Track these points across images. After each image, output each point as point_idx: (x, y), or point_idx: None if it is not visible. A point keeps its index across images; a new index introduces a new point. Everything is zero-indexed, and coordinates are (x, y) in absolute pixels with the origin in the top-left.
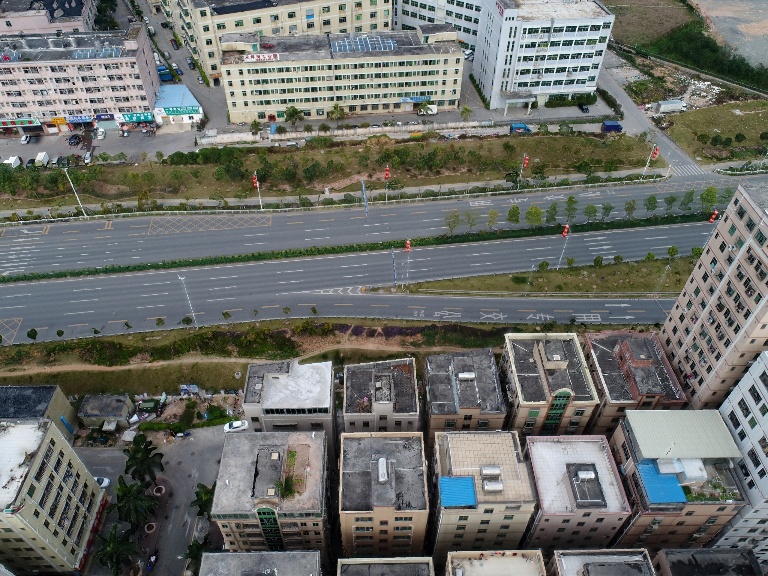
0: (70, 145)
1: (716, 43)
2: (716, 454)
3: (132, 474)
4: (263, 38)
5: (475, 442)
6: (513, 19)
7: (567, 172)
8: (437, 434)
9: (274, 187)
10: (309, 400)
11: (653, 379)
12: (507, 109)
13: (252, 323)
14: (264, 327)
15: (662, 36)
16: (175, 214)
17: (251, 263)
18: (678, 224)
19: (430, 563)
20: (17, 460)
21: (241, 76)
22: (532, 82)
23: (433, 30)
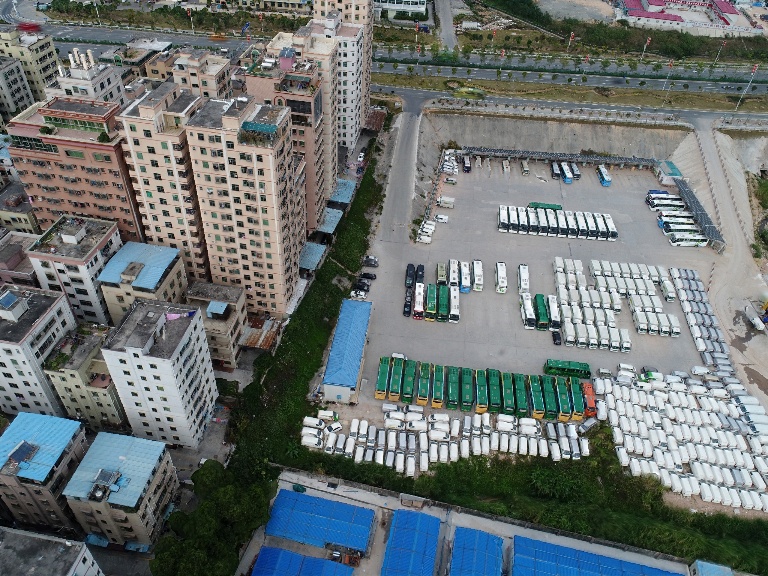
0: (106, 2)
1: (530, 1)
2: None
3: None
4: None
5: None
6: None
7: (377, 42)
8: None
9: (206, 28)
10: (155, 48)
11: None
12: None
13: None
14: None
15: None
16: (148, 31)
17: None
18: (419, 65)
19: None
20: None
21: None
22: None
23: None
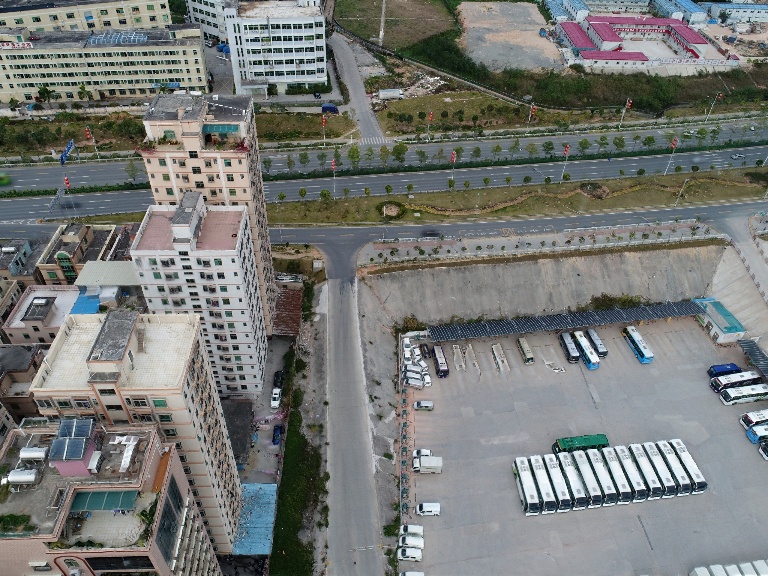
0: None
1: (456, 47)
2: (129, 283)
3: None
4: (34, 33)
5: None
6: (234, 17)
7: (269, 141)
8: None
9: (10, 149)
10: None
11: None
12: None
13: None
14: None
15: (418, 42)
16: None
17: None
18: (335, 177)
19: None
20: None
21: (1, 61)
22: (267, 72)
23: (180, 28)
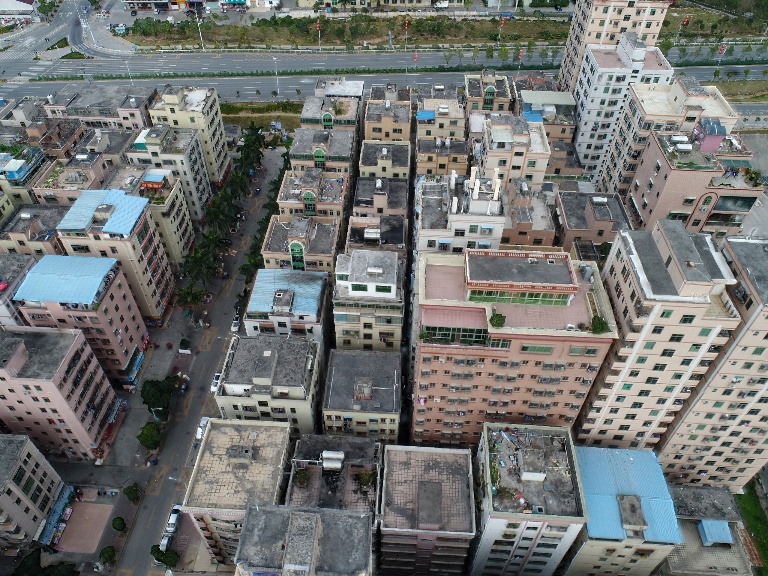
0: (187, 16)
1: None
2: (563, 103)
3: None
4: None
5: (438, 101)
6: None
7: (536, 41)
8: (419, 103)
9: (329, 41)
10: (351, 93)
11: (543, 88)
12: (500, 6)
13: None
14: None
15: None
16: (262, 52)
17: (313, 76)
18: None
19: (409, 143)
20: (200, 100)
21: None
22: None
23: None
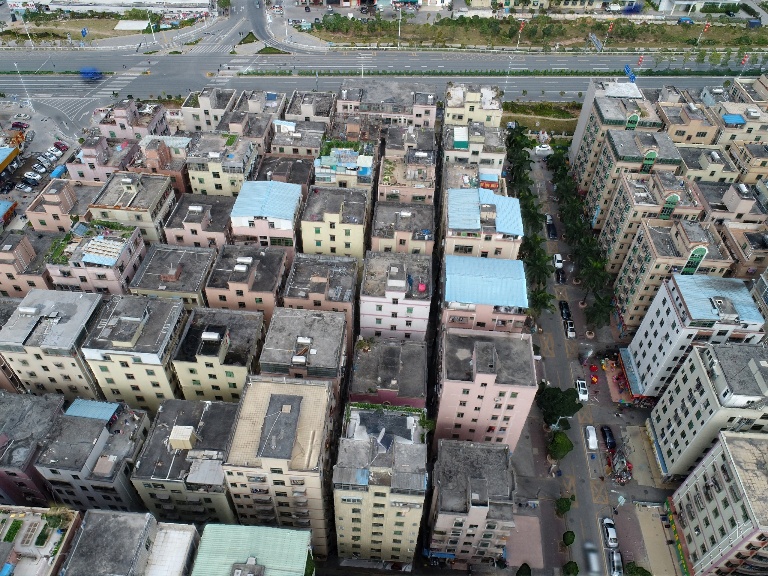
0: (362, 13)
1: None
2: None
3: (512, 142)
4: None
5: (737, 105)
6: None
7: (727, 46)
8: (711, 106)
9: (519, 41)
10: (630, 94)
11: None
12: None
13: (536, 102)
14: (548, 102)
15: None
16: (457, 51)
17: (521, 77)
18: None
19: (722, 147)
20: (489, 98)
21: None
22: None
23: None
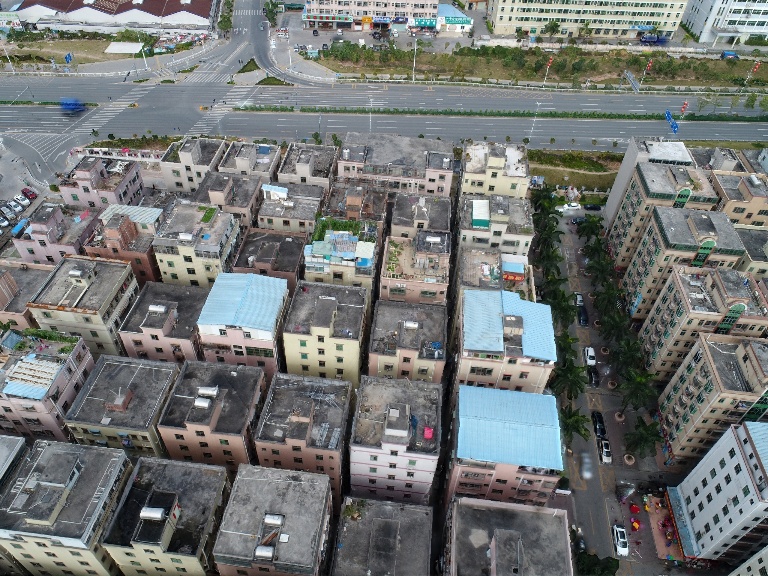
0: (374, 39)
1: None
2: None
3: (538, 206)
4: None
5: None
6: None
7: None
8: None
9: None
10: (678, 157)
11: None
12: None
13: (565, 151)
14: (578, 152)
15: None
16: (477, 86)
17: (548, 119)
18: None
19: None
20: (514, 161)
21: None
22: (740, 21)
23: None
